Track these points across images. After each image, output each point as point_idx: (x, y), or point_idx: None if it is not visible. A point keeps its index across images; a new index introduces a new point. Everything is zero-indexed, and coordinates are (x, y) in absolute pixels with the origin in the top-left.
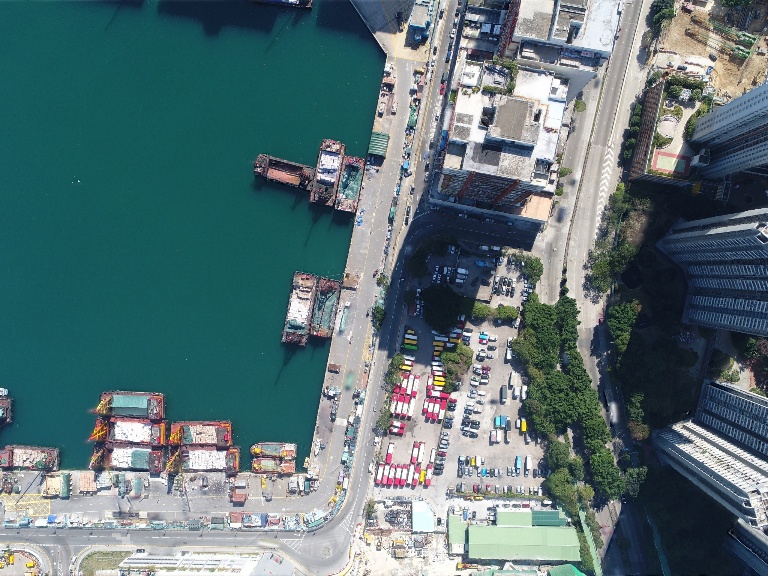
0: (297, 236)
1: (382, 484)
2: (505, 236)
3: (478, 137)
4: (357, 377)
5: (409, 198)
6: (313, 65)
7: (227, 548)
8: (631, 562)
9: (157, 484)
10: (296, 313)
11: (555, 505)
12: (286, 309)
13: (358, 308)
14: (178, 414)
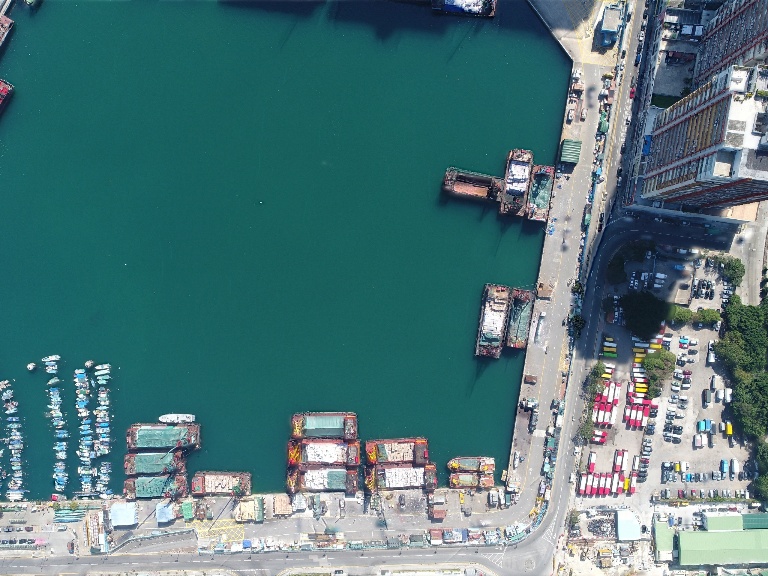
0: (486, 248)
1: (584, 494)
2: (702, 238)
3: (752, 143)
4: (554, 387)
5: (601, 204)
6: (497, 74)
7: (427, 565)
8: None
9: (352, 504)
10: (491, 326)
11: (763, 507)
12: (477, 322)
13: (553, 318)
14: (370, 432)
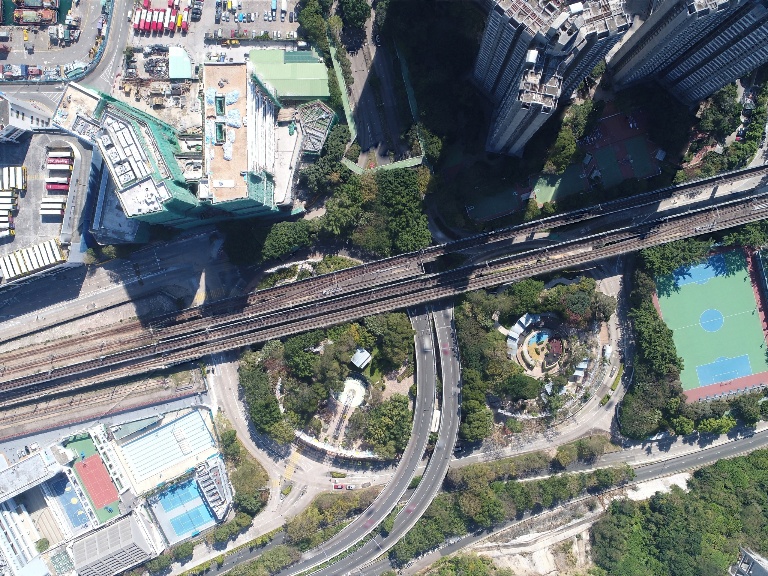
0: None
1: (141, 32)
2: None
3: None
4: None
5: None
6: None
7: None
8: (385, 106)
9: None
10: None
11: None
12: None
13: None
14: None
